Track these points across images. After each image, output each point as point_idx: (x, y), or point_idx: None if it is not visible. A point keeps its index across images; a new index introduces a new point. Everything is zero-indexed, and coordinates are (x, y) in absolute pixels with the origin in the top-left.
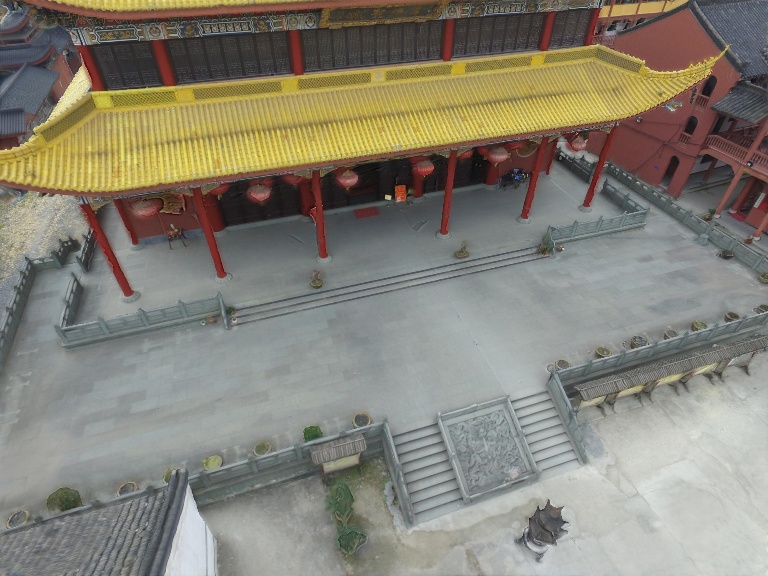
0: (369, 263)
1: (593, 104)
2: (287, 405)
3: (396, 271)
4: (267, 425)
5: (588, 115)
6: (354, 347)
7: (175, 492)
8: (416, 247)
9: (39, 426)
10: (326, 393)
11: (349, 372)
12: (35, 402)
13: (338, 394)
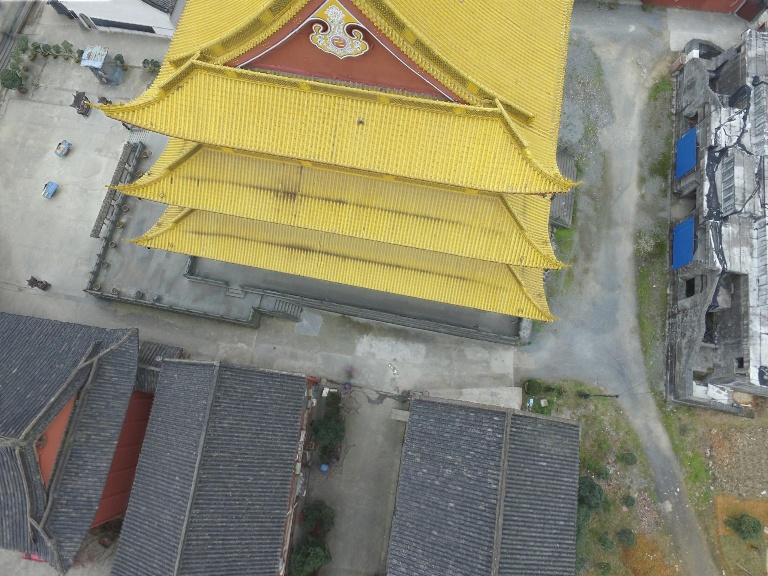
0: None
1: None
2: None
3: None
4: None
5: None
6: None
7: (157, 5)
8: None
9: None
10: None
11: None
12: None
13: None
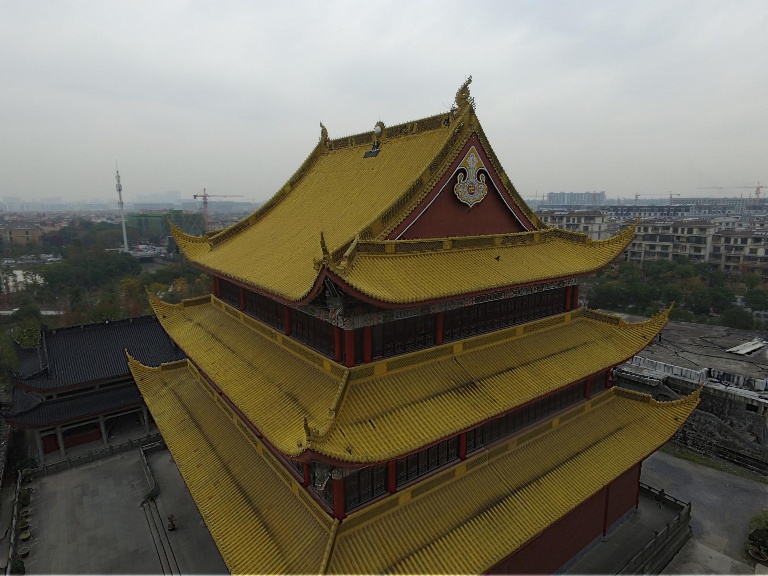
0: (199, 550)
1: (266, 572)
2: (59, 553)
3: (186, 570)
4: (47, 550)
5: (245, 574)
6: (103, 572)
7: None
8: (223, 575)
9: (87, 474)
10: (61, 569)
11: (77, 575)
12: (105, 466)
13: (57, 575)
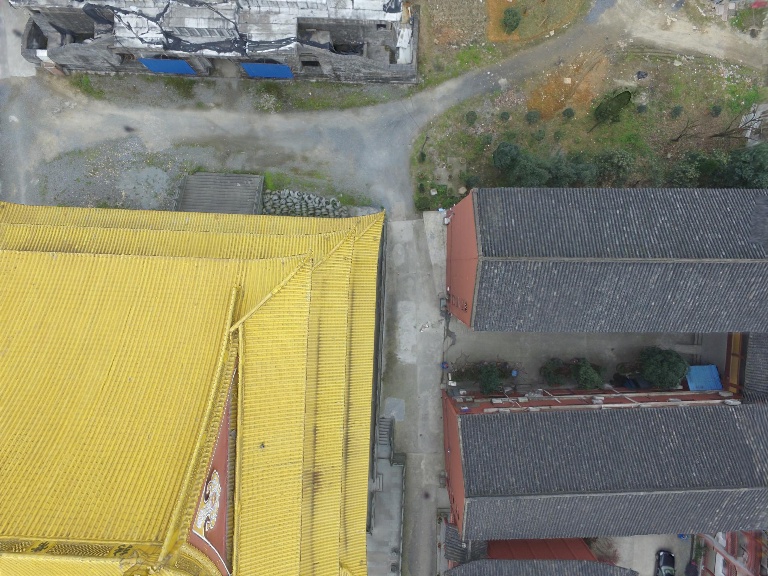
0: None
1: None
2: None
3: None
4: None
5: None
6: None
7: None
8: None
9: None
10: None
11: None
12: None
13: None
